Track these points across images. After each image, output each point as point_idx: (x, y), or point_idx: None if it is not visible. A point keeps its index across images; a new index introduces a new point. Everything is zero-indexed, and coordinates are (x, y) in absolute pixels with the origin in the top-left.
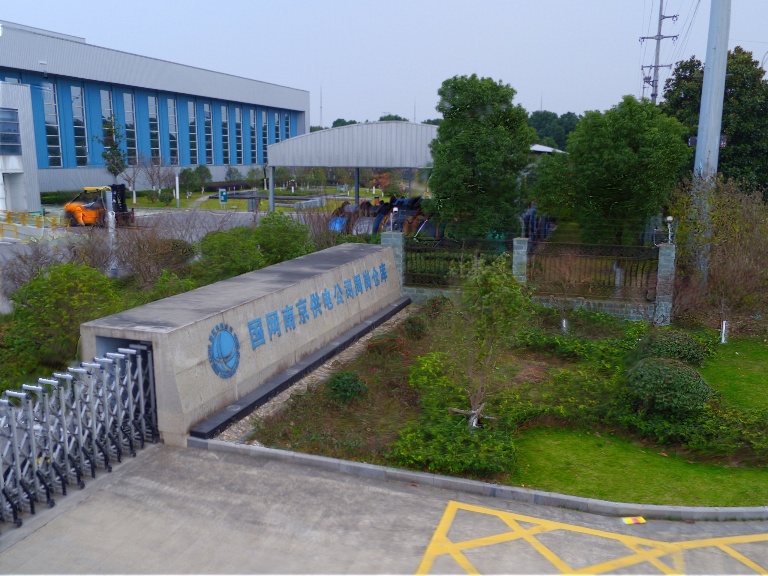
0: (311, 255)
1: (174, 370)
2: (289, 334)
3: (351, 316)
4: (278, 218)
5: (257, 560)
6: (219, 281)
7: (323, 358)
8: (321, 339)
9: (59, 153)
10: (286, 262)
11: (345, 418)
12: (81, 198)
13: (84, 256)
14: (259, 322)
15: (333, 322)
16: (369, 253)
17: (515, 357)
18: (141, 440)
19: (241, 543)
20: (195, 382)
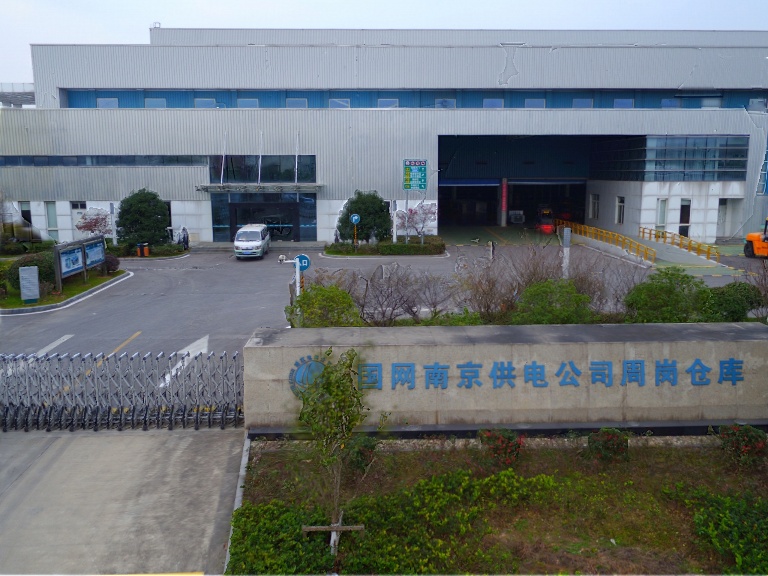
0: (637, 325)
1: (244, 376)
2: (432, 392)
3: (594, 407)
4: (671, 275)
5: (89, 507)
6: (440, 325)
7: (474, 432)
8: (503, 414)
9: (765, 179)
10: (575, 325)
11: (295, 471)
12: (520, 233)
13: (482, 285)
14: (379, 368)
15: (540, 403)
16: (703, 339)
17: (685, 548)
18: (236, 421)
19: (110, 496)
20: (265, 393)
